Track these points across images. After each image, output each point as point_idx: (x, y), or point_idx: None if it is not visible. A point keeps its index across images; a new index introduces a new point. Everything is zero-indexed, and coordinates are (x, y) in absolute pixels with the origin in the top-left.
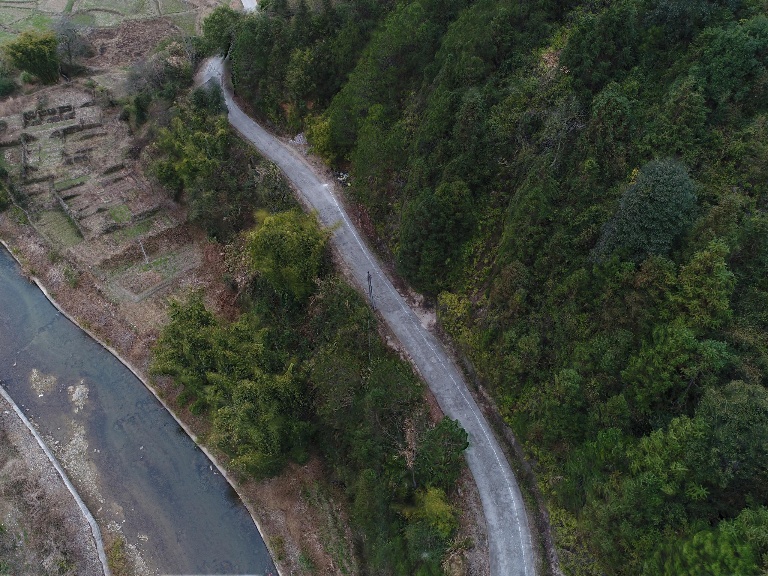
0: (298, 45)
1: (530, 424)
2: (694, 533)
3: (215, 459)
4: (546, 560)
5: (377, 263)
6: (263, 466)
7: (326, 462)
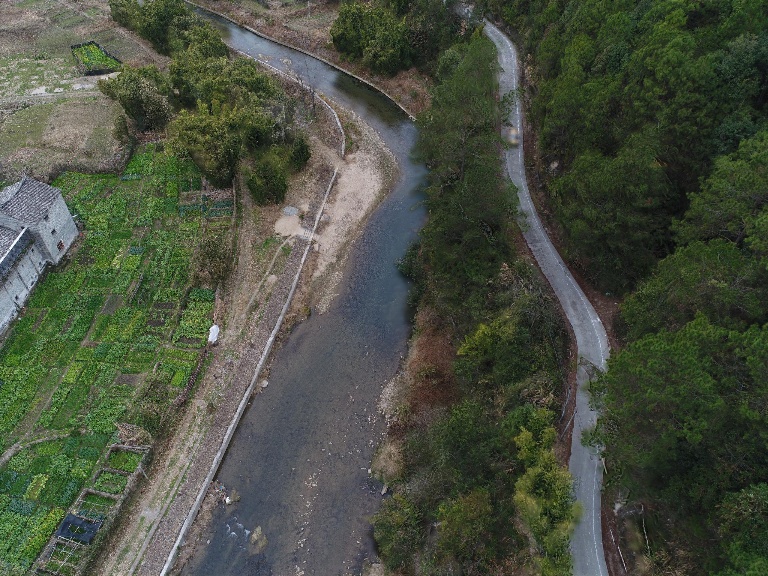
0: None
1: (516, 8)
2: None
3: (362, 78)
4: (521, 54)
5: None
6: (392, 60)
7: (419, 70)
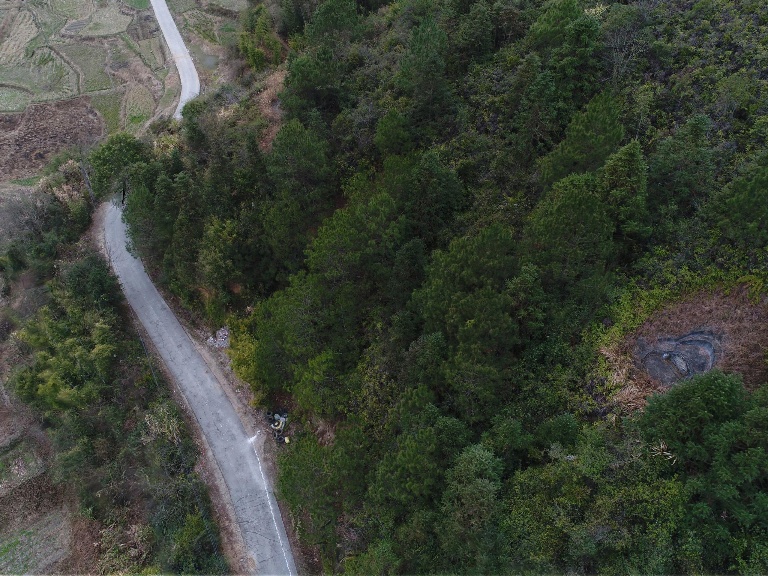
0: (215, 211)
1: None
2: None
3: None
4: None
5: None
6: None
7: None
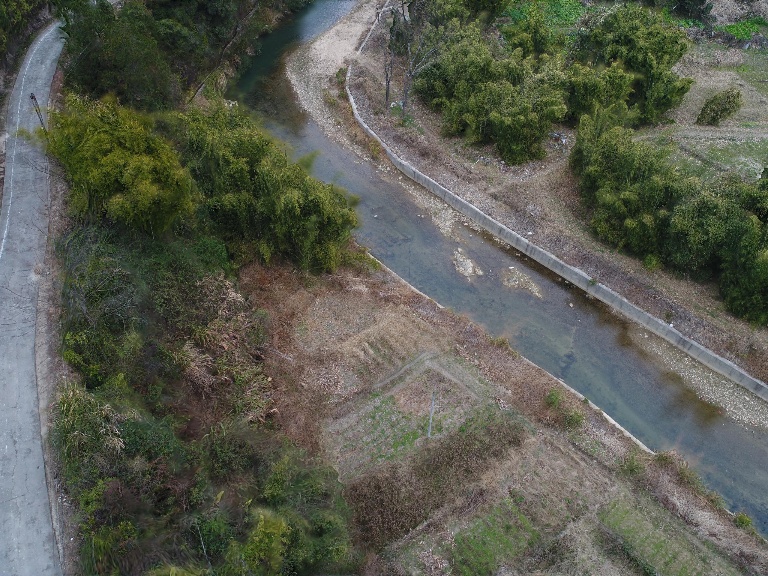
0: None
1: None
2: None
3: None
4: None
5: (0, 212)
6: None
7: None
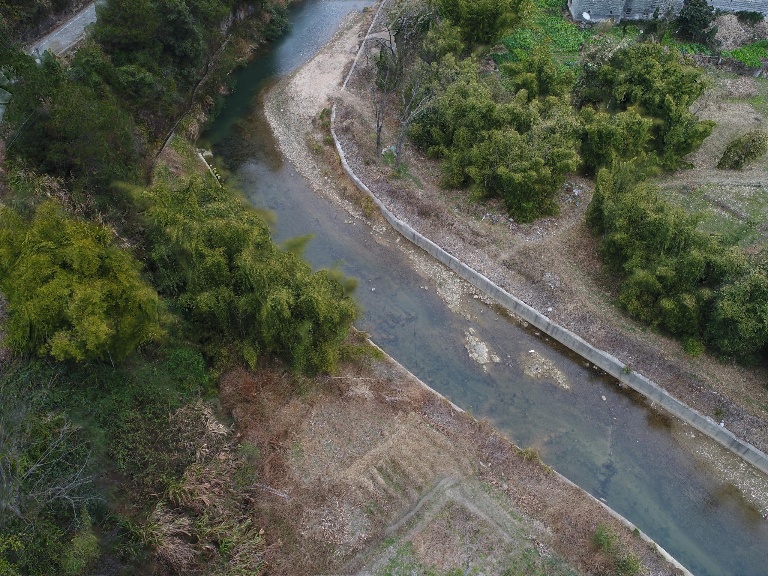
0: None
1: None
2: None
3: None
4: None
5: None
6: None
7: None
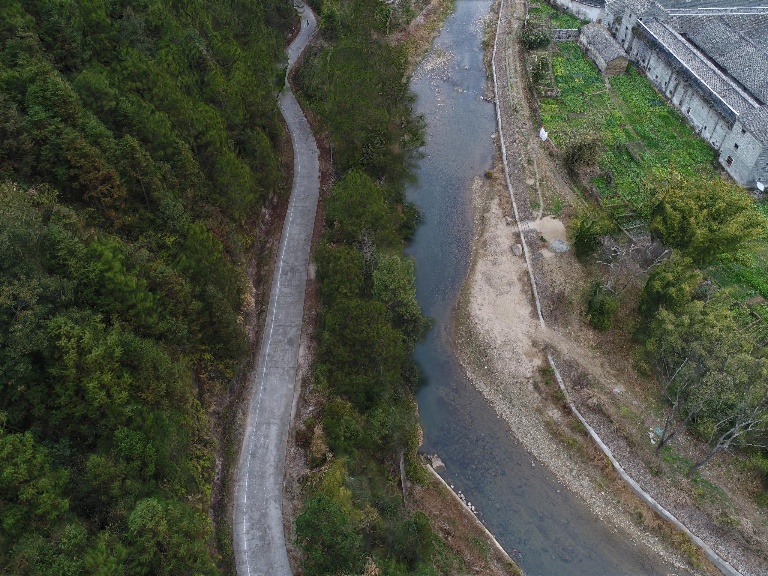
0: None
1: (205, 567)
2: (116, 298)
3: None
4: (225, 472)
5: None
6: None
7: None
